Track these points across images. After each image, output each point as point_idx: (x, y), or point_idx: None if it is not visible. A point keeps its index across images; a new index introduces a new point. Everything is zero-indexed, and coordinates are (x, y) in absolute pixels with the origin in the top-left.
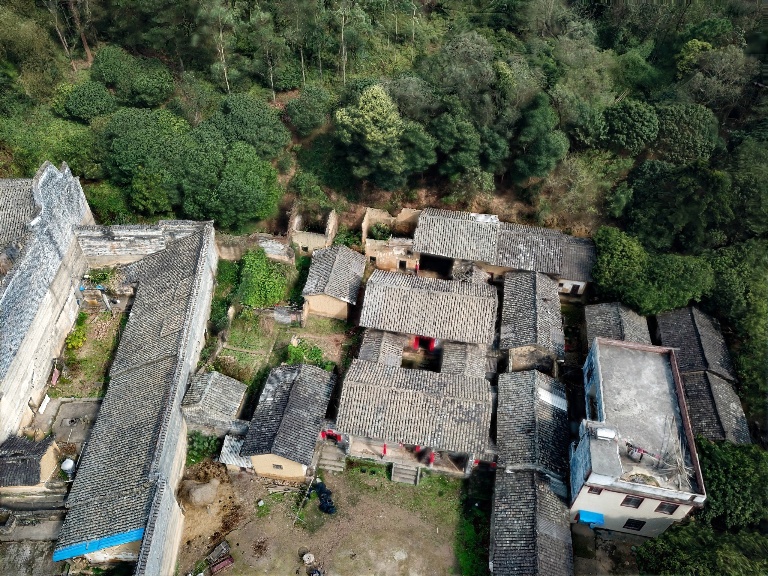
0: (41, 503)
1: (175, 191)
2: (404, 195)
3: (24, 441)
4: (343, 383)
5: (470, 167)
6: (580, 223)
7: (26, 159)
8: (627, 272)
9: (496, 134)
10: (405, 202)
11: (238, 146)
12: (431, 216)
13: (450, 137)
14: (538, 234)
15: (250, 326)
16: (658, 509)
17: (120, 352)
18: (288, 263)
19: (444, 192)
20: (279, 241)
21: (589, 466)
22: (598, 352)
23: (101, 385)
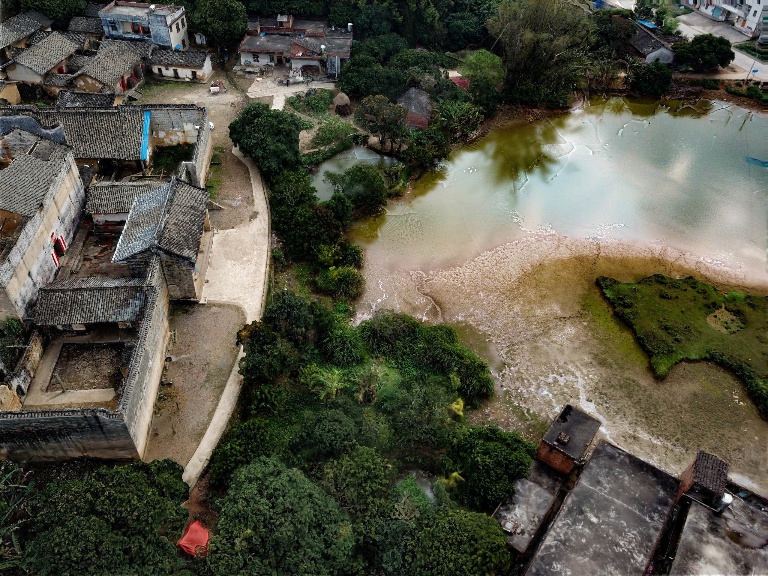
0: None
1: None
2: None
3: None
4: (85, 73)
5: None
6: (2, 20)
7: None
8: (61, 2)
9: None
10: None
11: None
12: None
13: None
14: (12, 17)
15: None
16: (182, 26)
17: None
18: None
19: None
20: None
21: (163, 17)
22: (107, 13)
23: None
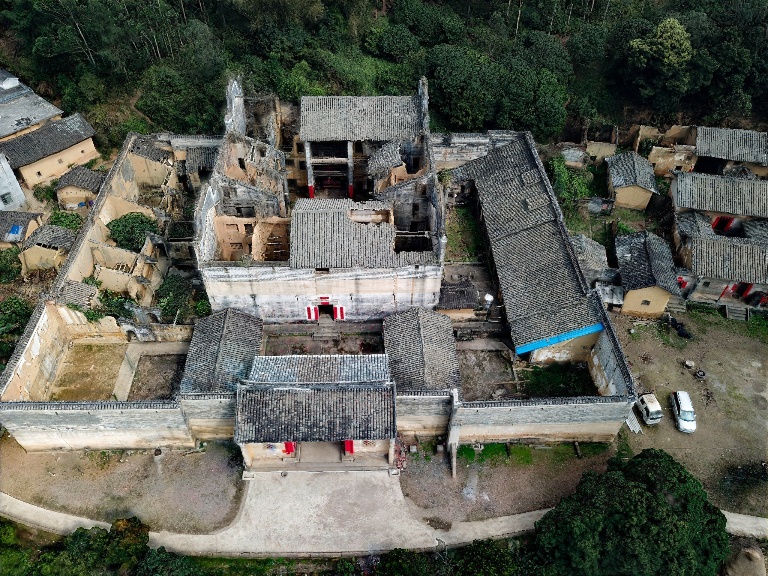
0: (468, 327)
1: (492, 109)
2: (663, 118)
3: (448, 282)
4: (692, 240)
5: (735, 89)
6: None
7: (357, 86)
8: None
9: (763, 60)
10: (663, 124)
11: (545, 72)
12: (708, 128)
13: (730, 61)
14: None
15: (570, 213)
16: None
17: (490, 225)
18: (580, 169)
19: (699, 114)
20: (581, 149)
21: None
22: None
23: (468, 254)
